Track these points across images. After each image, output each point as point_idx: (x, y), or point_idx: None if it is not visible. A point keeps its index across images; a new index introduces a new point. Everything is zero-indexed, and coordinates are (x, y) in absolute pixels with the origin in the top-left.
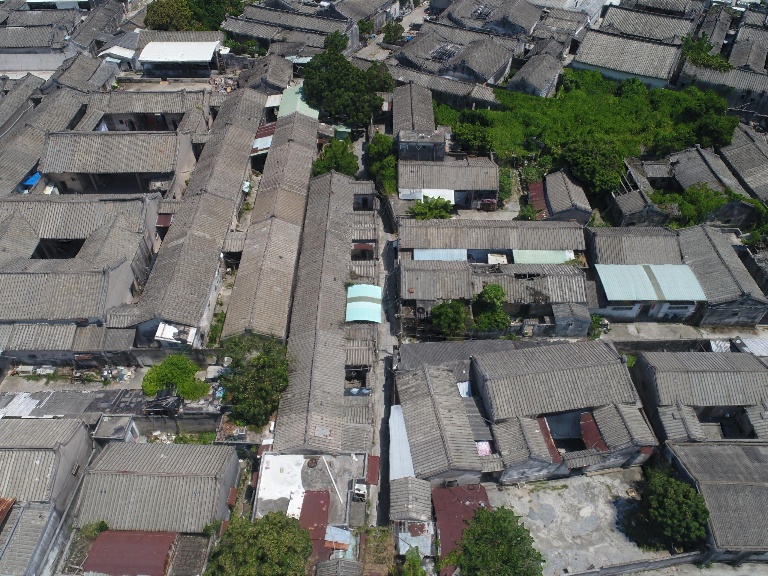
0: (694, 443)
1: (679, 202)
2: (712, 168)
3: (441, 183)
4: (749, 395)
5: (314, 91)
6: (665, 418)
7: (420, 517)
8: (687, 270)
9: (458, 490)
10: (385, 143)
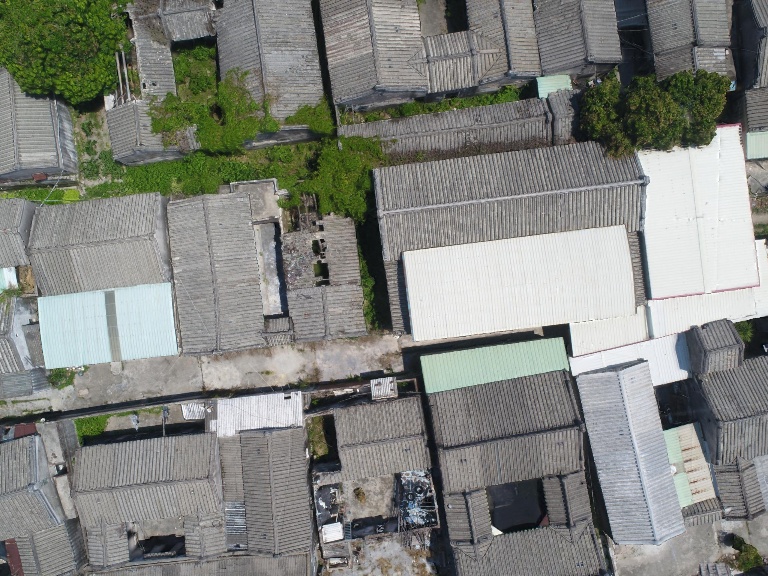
0: (112, 570)
1: (196, 124)
2: (257, 37)
3: None
4: (184, 507)
5: None
6: (90, 539)
7: None
8: (164, 296)
9: None
10: None
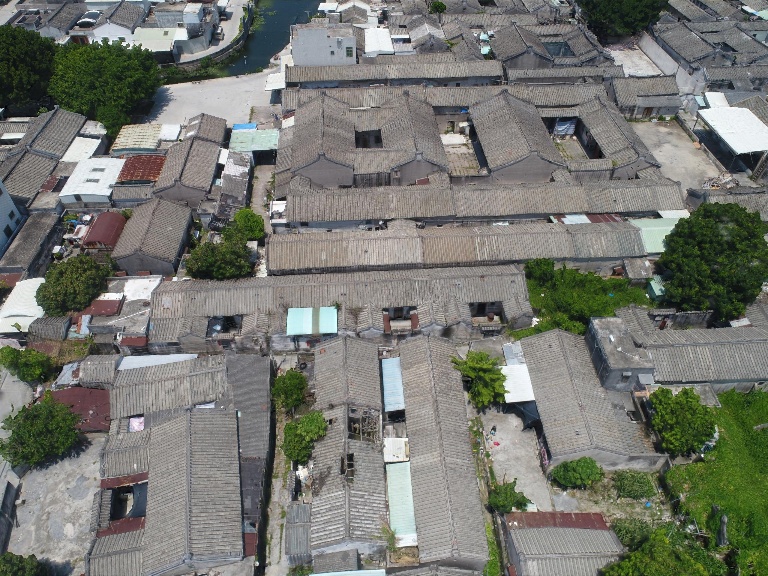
0: None
1: None
2: None
3: (541, 382)
4: None
5: (675, 228)
6: None
7: (81, 371)
8: None
9: (108, 408)
10: (583, 305)
